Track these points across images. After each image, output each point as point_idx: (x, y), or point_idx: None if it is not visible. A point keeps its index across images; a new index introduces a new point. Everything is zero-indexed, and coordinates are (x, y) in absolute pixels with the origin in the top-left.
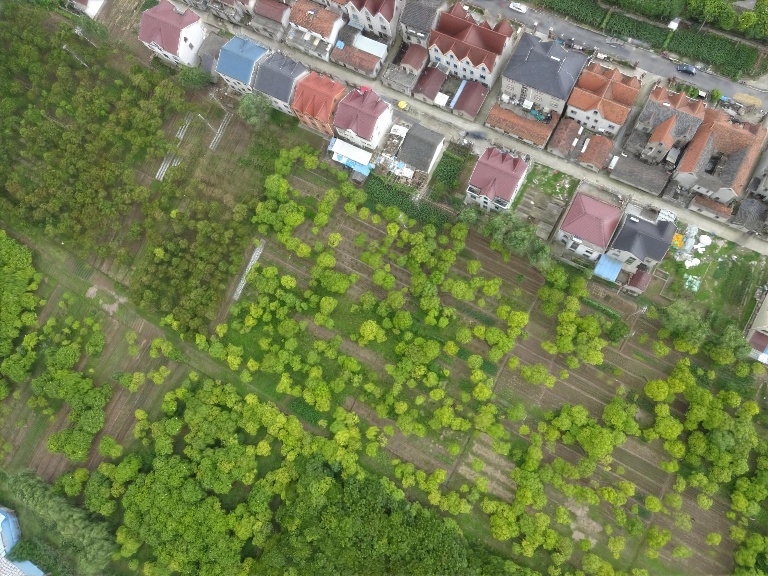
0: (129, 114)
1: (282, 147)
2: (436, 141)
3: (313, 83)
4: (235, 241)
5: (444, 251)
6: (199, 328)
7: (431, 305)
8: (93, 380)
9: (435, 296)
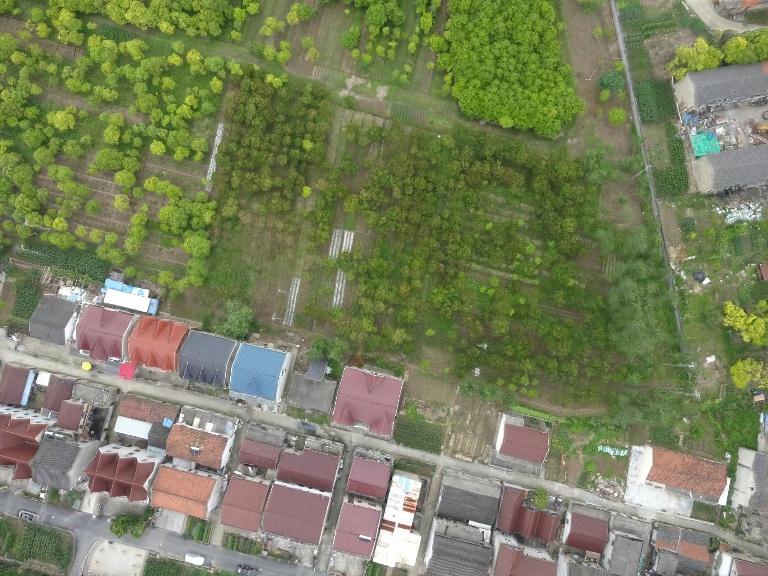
0: (398, 293)
1: (214, 295)
2: (33, 326)
3: (161, 356)
4: (229, 177)
5: (2, 212)
6: (239, 79)
7: (5, 156)
8: (349, 6)
9: (4, 166)
